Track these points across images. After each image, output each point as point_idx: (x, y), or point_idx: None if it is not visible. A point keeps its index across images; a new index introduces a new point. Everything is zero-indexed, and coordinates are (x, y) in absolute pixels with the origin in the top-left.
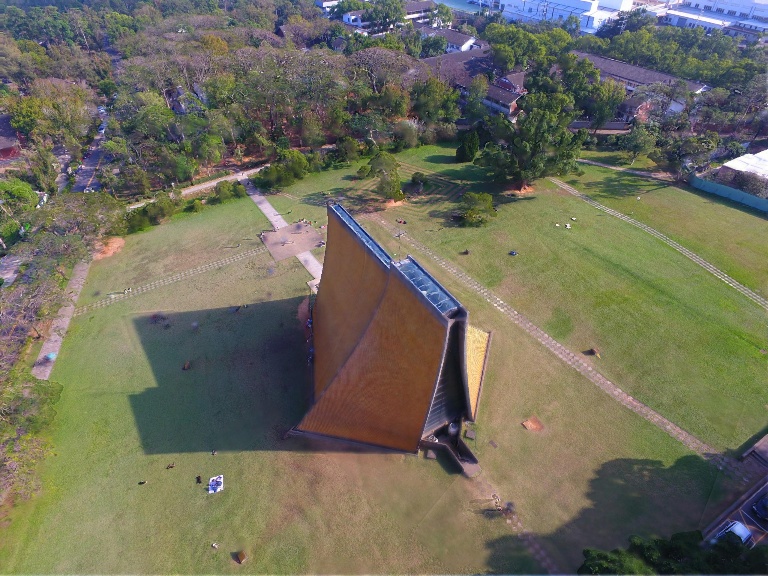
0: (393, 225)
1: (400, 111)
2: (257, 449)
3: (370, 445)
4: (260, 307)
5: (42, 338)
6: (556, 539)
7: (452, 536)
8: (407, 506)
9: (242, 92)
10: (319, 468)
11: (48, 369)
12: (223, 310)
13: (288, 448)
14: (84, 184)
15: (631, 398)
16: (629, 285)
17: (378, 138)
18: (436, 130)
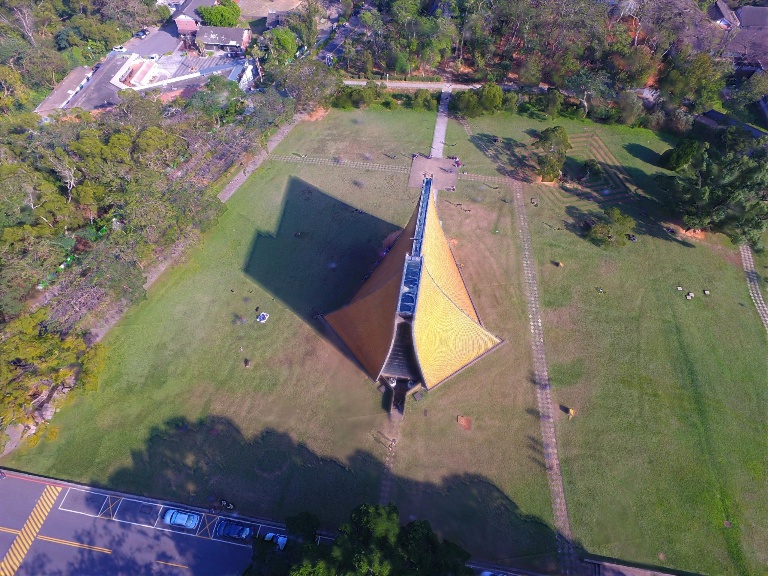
0: (524, 202)
1: (637, 80)
2: (295, 313)
3: (354, 357)
4: (368, 218)
5: (243, 166)
6: (403, 489)
7: (351, 439)
8: (344, 405)
9: (493, 2)
10: (317, 348)
11: (234, 189)
12: (345, 206)
13: (311, 325)
14: (337, 43)
15: (557, 462)
16: (676, 386)
17: (591, 102)
18: (667, 116)
